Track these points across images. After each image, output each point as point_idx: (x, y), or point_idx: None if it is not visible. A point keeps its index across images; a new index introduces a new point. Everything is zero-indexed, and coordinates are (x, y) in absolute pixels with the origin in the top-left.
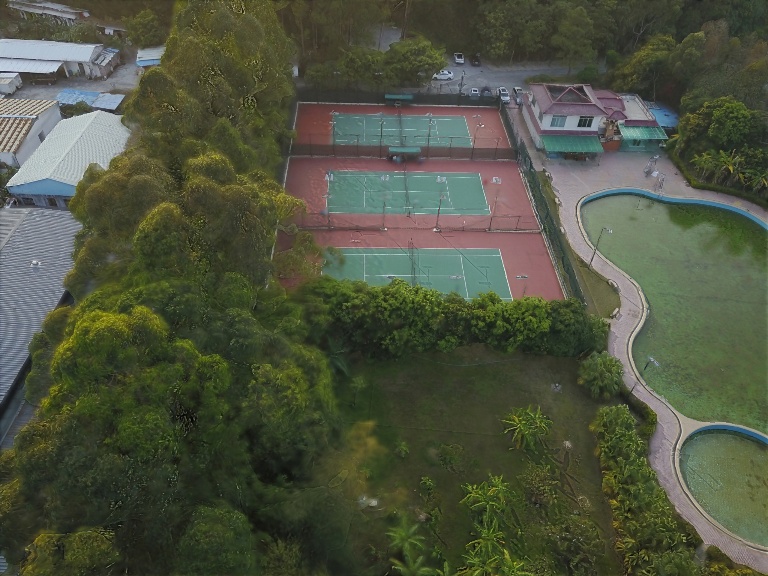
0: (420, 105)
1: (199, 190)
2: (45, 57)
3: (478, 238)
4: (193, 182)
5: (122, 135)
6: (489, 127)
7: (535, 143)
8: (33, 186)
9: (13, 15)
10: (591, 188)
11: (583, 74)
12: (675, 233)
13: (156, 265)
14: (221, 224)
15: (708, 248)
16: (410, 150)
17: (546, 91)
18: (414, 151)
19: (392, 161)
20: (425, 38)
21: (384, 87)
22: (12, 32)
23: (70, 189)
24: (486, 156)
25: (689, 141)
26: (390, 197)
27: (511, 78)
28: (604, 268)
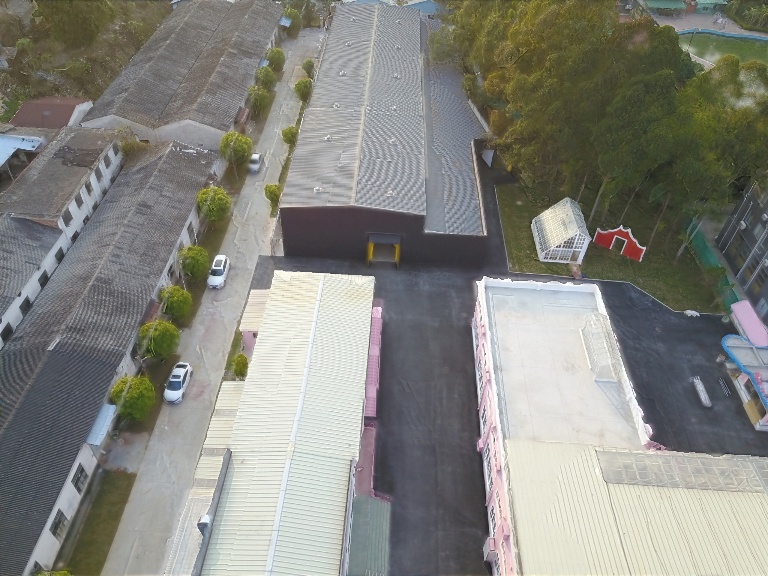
0: None
1: None
2: None
3: None
4: None
5: None
6: None
7: (639, 7)
8: (360, 3)
9: None
10: (679, 28)
11: None
12: (734, 49)
13: None
14: None
15: (755, 55)
16: None
17: None
18: None
19: None
20: None
21: None
22: None
23: None
24: None
25: (742, 3)
26: None
27: None
28: (693, 58)
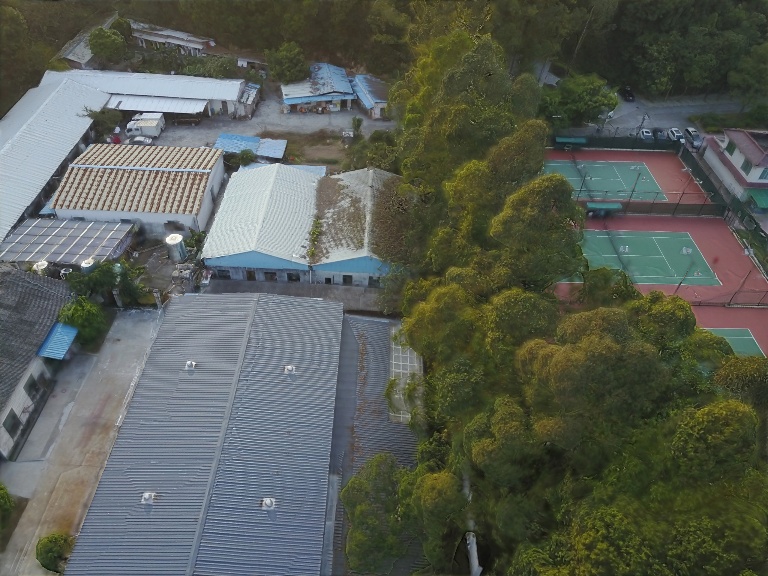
0: (591, 148)
1: (763, 379)
2: (189, 95)
3: (719, 315)
4: (752, 367)
5: (309, 193)
6: (675, 175)
7: None
8: (234, 258)
9: (130, 43)
10: None
11: (757, 113)
12: None
13: (698, 477)
14: (767, 417)
15: None
16: (610, 206)
17: (751, 139)
18: (615, 207)
19: (588, 217)
20: (599, 76)
21: (554, 129)
22: (135, 63)
23: (275, 261)
24: (690, 212)
25: None
26: (603, 263)
27: (671, 115)
28: None
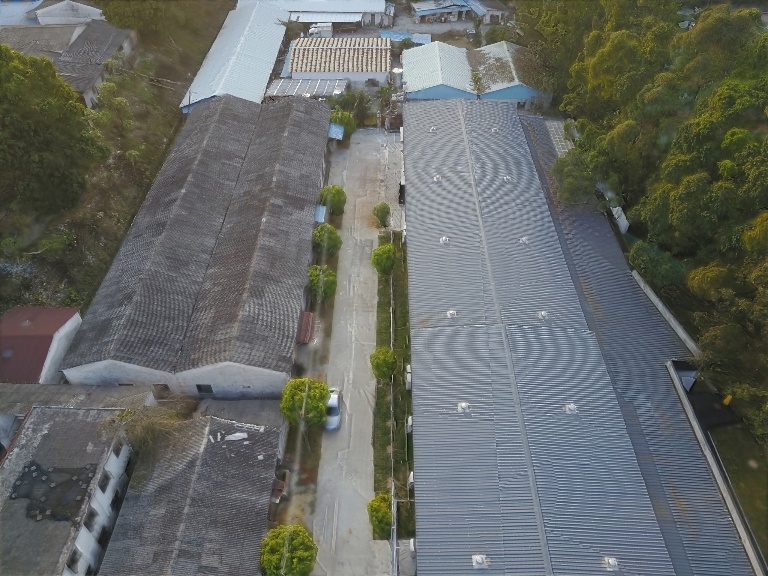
0: None
1: None
2: (348, 10)
3: None
4: None
5: (463, 58)
6: None
7: None
8: (427, 91)
9: None
10: None
11: None
12: None
13: None
14: None
15: None
16: None
17: None
18: None
19: None
20: None
21: None
22: None
23: (455, 93)
24: None
25: None
26: None
27: None
28: None
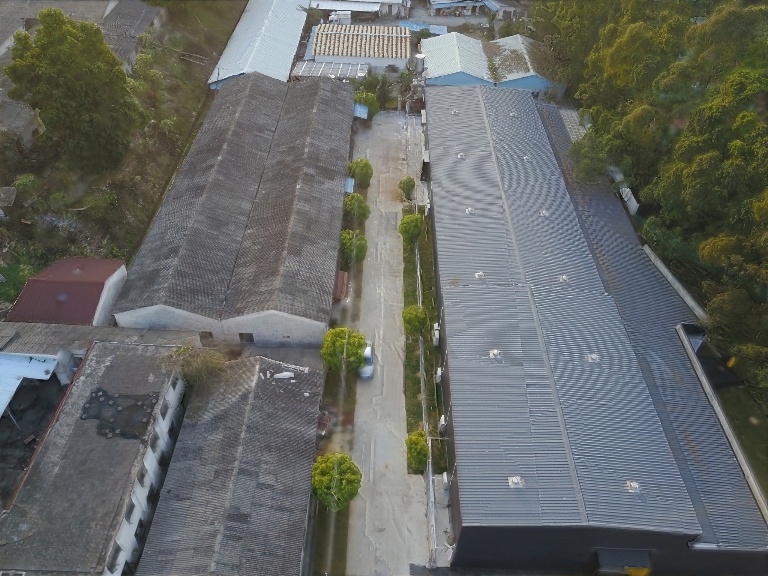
0: None
1: None
2: None
3: None
4: None
5: (479, 49)
6: None
7: None
8: (447, 78)
9: None
10: None
11: None
12: None
13: None
14: None
15: None
16: None
17: None
18: None
19: None
20: None
21: None
22: None
23: (473, 81)
24: None
25: None
26: None
27: None
28: None
